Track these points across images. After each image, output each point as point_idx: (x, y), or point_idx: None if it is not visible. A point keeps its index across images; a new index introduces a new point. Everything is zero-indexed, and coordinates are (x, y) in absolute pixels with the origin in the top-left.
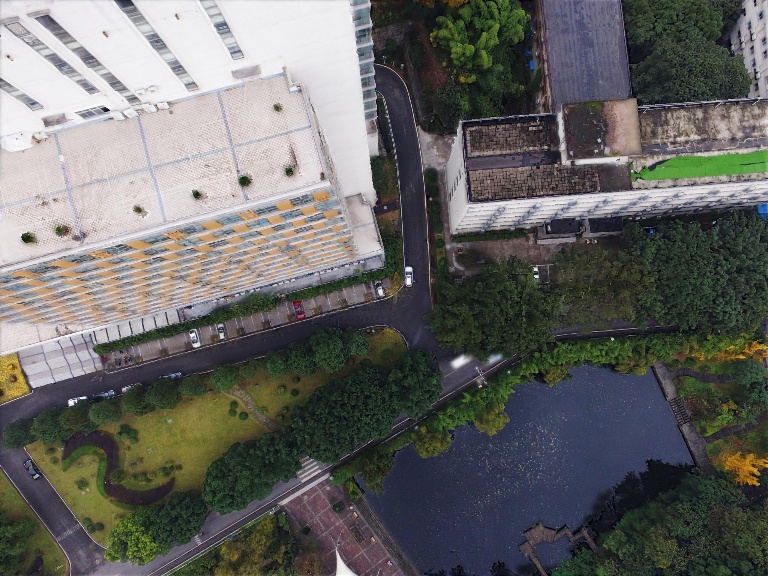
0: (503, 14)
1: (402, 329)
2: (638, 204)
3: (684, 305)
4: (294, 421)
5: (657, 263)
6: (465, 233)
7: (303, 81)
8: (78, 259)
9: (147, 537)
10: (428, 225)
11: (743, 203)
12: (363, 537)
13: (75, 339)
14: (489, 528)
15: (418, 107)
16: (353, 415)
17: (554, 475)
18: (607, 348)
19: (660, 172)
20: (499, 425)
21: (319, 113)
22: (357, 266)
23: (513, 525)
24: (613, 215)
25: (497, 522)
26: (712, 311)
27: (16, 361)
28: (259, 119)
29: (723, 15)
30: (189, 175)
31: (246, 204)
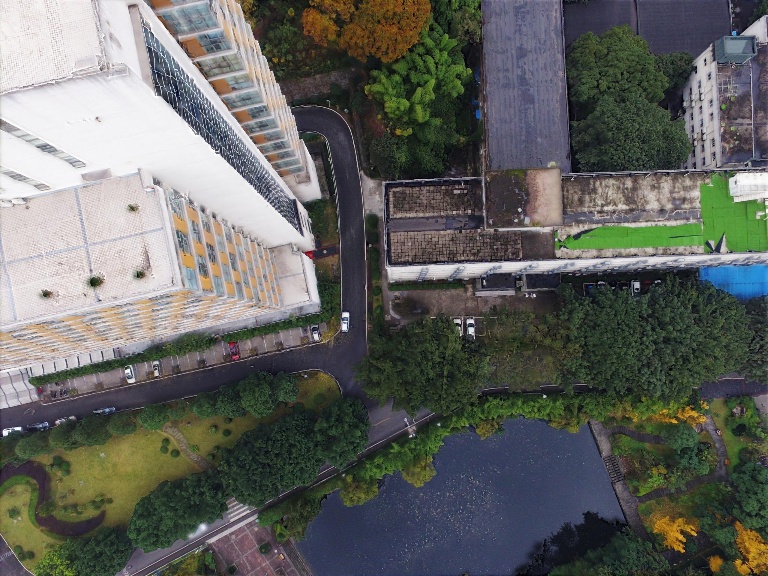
0: (440, 68)
1: (336, 374)
2: (570, 266)
3: (608, 373)
4: (220, 464)
5: (584, 329)
6: (403, 281)
7: (168, 176)
8: None
9: (71, 571)
10: (367, 271)
11: (682, 267)
12: None
13: None
14: None
15: (361, 152)
16: (276, 463)
17: (483, 527)
18: (539, 405)
19: (585, 241)
20: (425, 478)
21: (203, 195)
22: (293, 310)
23: (439, 575)
24: (550, 272)
25: (423, 571)
26: (638, 380)
27: None
28: (115, 218)
29: (673, 73)
30: (42, 272)
31: (96, 305)
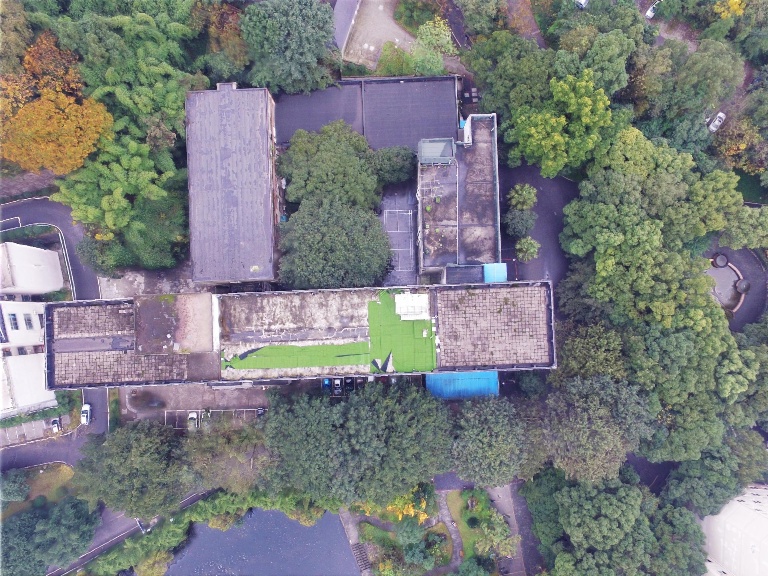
0: (131, 175)
1: None
2: None
3: (299, 484)
4: None
5: (278, 438)
6: None
7: None
8: None
9: None
10: None
11: None
12: None
13: None
14: None
15: None
16: None
17: None
18: (271, 500)
19: (251, 361)
20: (153, 575)
21: None
22: None
23: None
24: None
25: None
26: None
27: None
28: None
29: (392, 168)
30: None
31: None
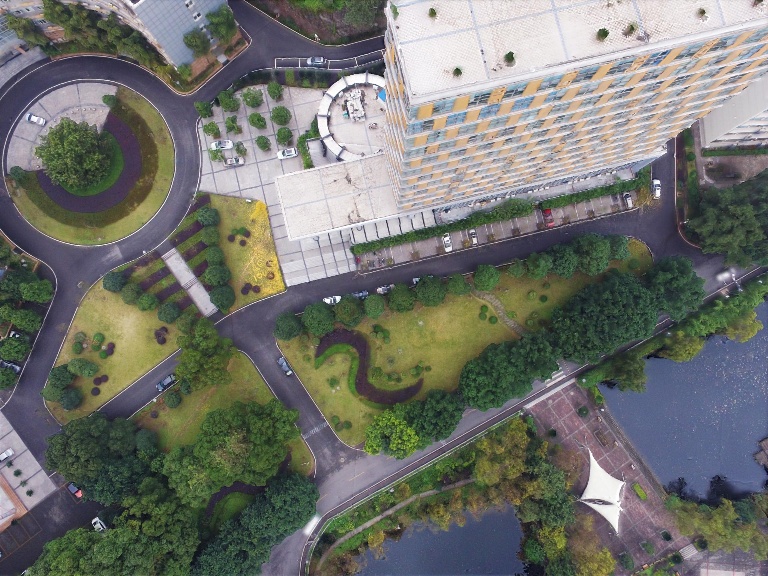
0: None
1: (648, 240)
2: None
3: None
4: (557, 321)
5: None
6: (715, 147)
7: None
8: (616, 67)
9: (412, 430)
10: (676, 139)
11: None
12: (607, 441)
13: (333, 239)
14: (725, 437)
15: None
16: (624, 313)
17: None
18: None
19: None
20: (755, 331)
21: None
22: (608, 177)
23: (749, 435)
24: None
25: (733, 431)
26: None
27: (275, 258)
28: None
29: None
30: None
31: None
